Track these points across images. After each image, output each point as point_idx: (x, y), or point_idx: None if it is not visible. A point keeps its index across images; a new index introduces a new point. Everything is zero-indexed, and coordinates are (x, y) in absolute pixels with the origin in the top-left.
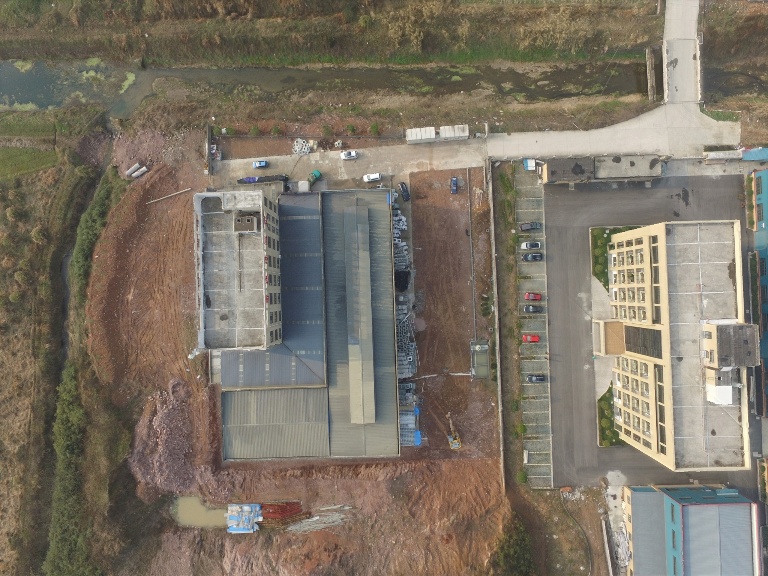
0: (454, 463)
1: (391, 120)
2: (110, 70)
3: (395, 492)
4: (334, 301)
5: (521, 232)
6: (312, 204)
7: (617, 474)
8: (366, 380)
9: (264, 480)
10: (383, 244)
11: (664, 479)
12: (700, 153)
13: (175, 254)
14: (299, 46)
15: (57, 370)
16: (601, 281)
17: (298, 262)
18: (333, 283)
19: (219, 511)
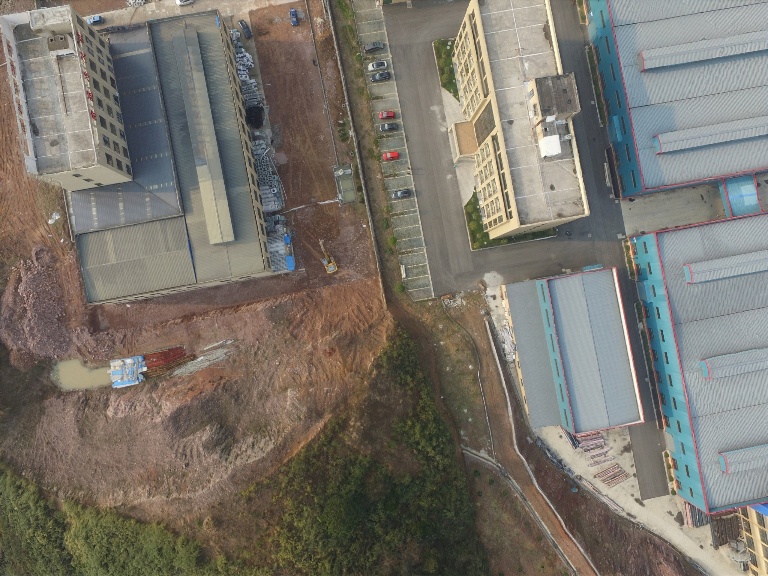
0: (334, 288)
1: None
2: None
3: (275, 319)
4: (178, 129)
5: (366, 54)
6: (142, 38)
7: (493, 275)
8: (219, 199)
9: (145, 333)
10: (219, 67)
11: (538, 273)
12: None
13: None
14: None
15: None
16: (451, 92)
17: (137, 98)
18: (174, 112)
19: (102, 370)
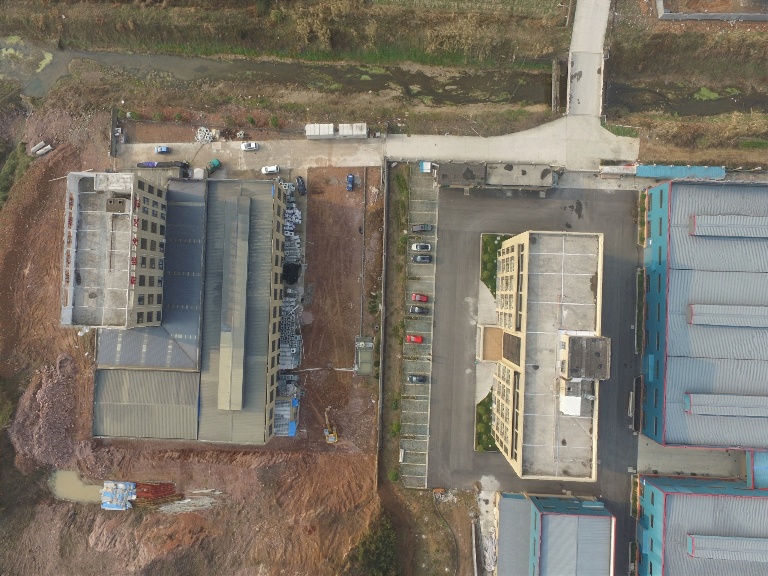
0: (330, 457)
1: (295, 115)
2: (29, 49)
3: (266, 480)
4: (212, 288)
5: (413, 233)
6: (199, 191)
7: (491, 479)
8: (235, 367)
9: (142, 460)
10: (264, 235)
11: (537, 488)
12: (597, 166)
13: None
14: (211, 36)
15: None
16: (489, 287)
17: (182, 247)
18: (213, 270)
19: (95, 487)
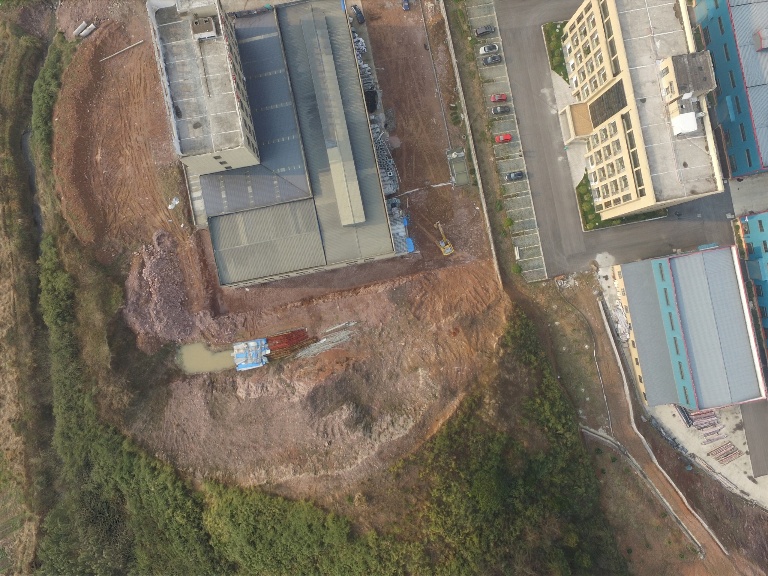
0: (449, 270)
1: None
2: None
3: (397, 301)
4: (306, 112)
5: (477, 38)
6: (268, 22)
7: (605, 256)
8: (350, 180)
9: (265, 316)
10: (345, 50)
11: (649, 253)
12: None
13: (138, 108)
14: None
15: (34, 248)
16: (560, 75)
17: (264, 82)
18: (302, 95)
19: (225, 353)
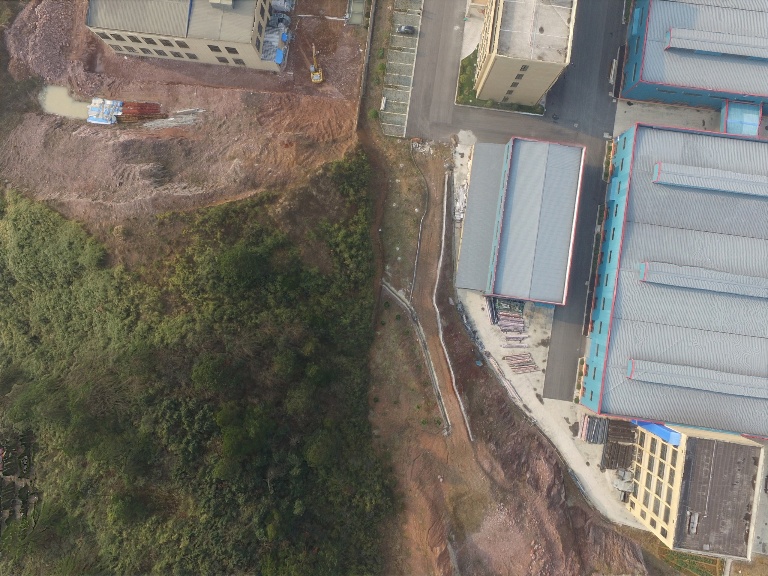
0: (314, 99)
1: None
2: None
3: (249, 104)
4: None
5: None
6: None
7: (468, 134)
8: None
9: (131, 84)
10: None
11: None
12: None
13: None
14: None
15: None
16: None
17: None
18: None
19: (84, 104)
